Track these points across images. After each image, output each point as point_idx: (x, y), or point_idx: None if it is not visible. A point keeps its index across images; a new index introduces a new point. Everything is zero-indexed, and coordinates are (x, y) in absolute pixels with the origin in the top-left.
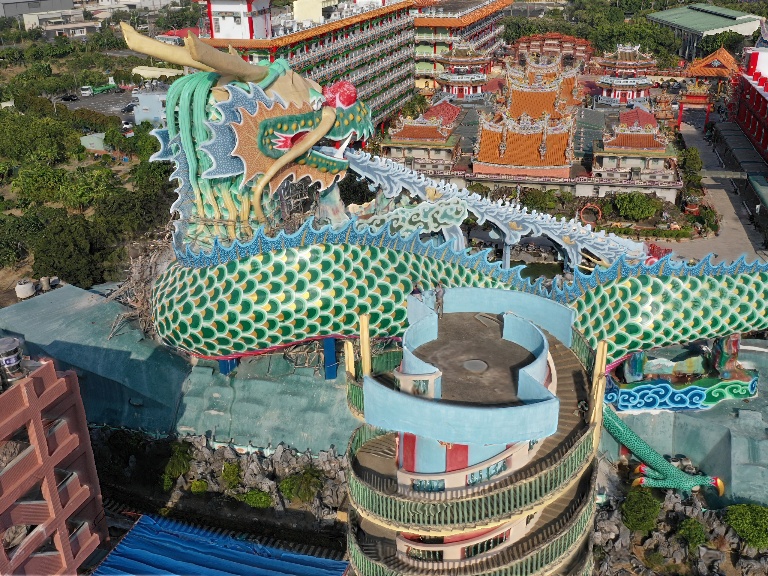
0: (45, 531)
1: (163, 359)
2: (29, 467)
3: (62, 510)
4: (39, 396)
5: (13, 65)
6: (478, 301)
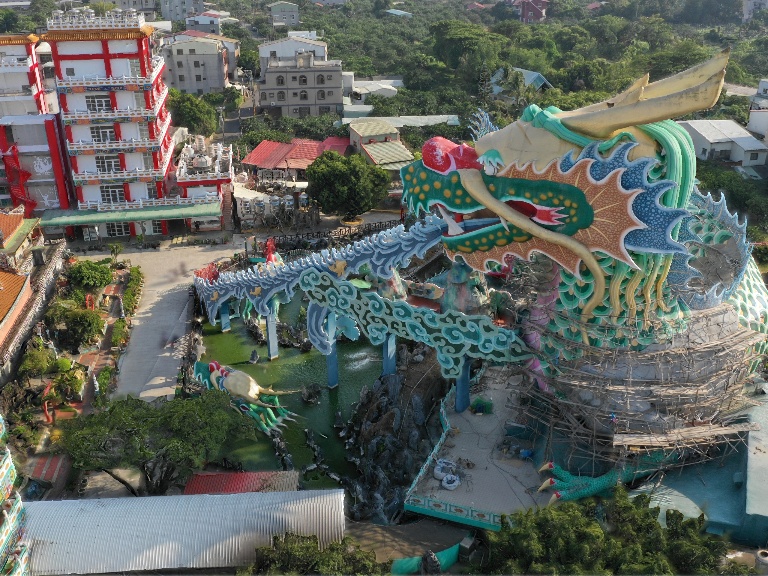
0: None
1: (760, 380)
2: None
3: None
4: None
5: None
6: None
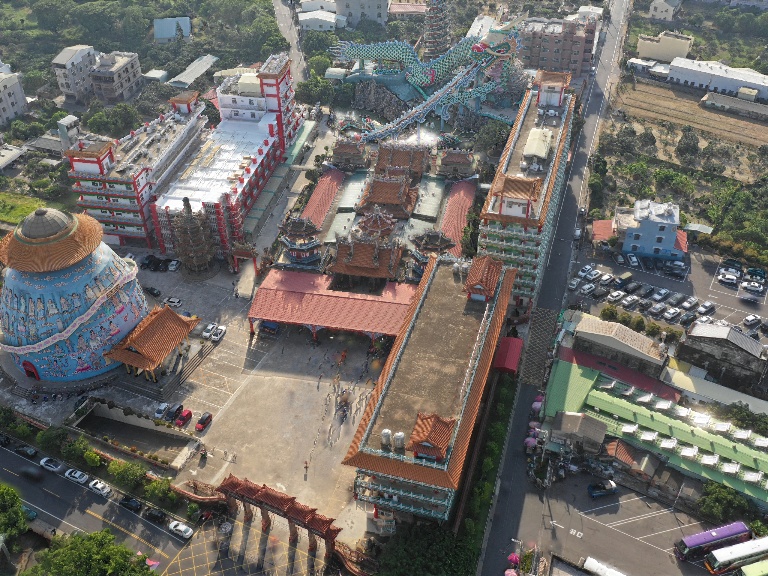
0: None
1: None
2: None
3: None
4: None
5: None
6: None
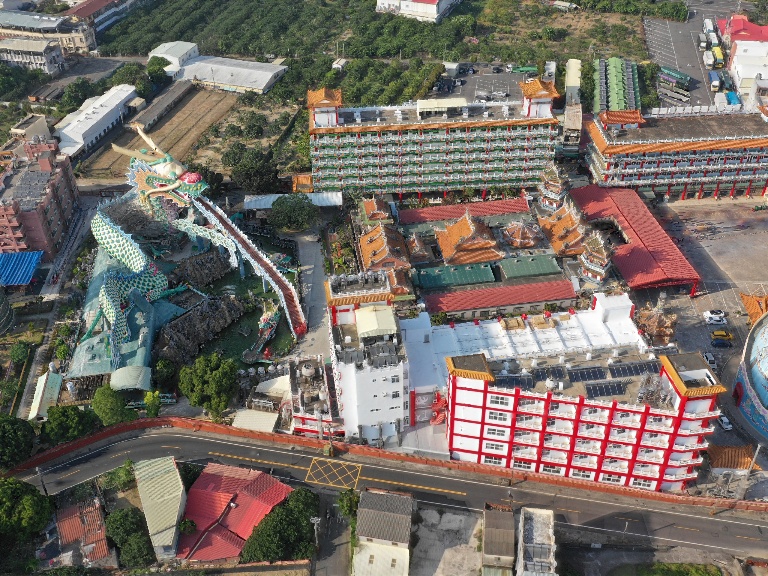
0: (8, 236)
1: None
2: (5, 223)
3: (13, 235)
4: (6, 211)
5: (576, 13)
6: None
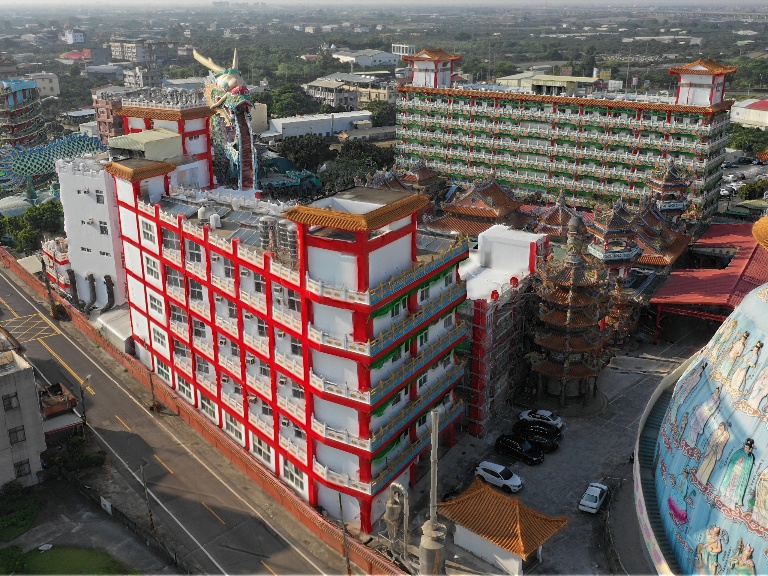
0: None
1: None
2: None
3: None
4: None
5: None
6: (31, 85)
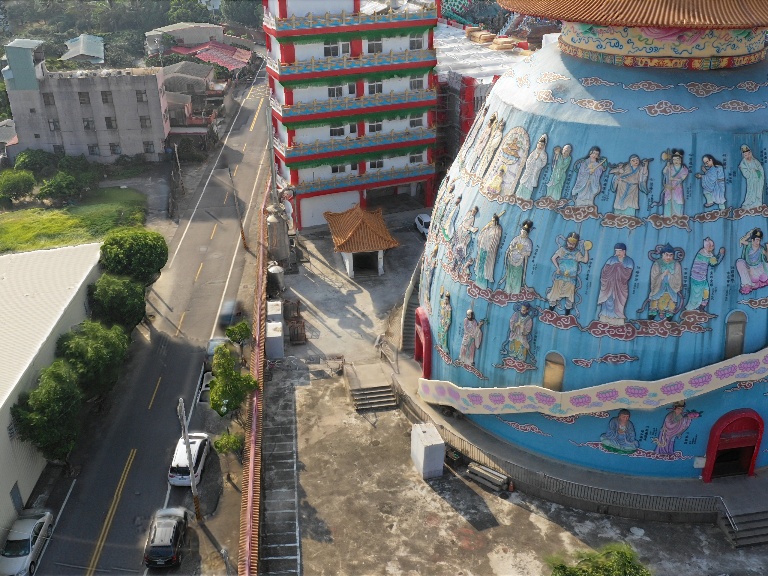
0: None
1: None
2: None
3: None
4: None
5: None
6: None
